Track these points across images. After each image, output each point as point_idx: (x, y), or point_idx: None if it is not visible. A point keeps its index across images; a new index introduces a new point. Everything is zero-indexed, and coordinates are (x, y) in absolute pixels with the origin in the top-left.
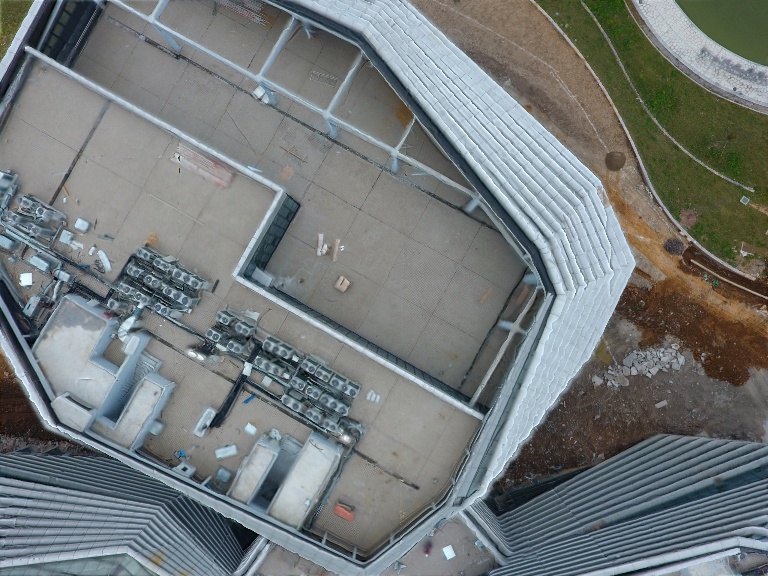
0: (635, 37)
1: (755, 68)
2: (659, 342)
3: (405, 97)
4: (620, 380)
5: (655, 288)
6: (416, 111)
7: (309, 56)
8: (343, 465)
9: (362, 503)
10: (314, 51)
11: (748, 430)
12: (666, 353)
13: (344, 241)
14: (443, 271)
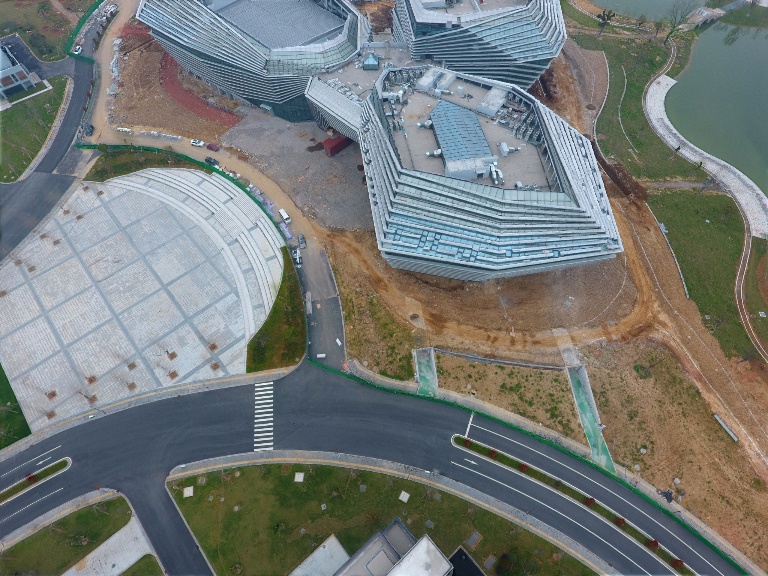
0: (637, 99)
1: (678, 135)
2: None
3: None
4: None
5: None
6: None
7: None
8: None
9: None
10: None
11: None
12: None
13: (487, 4)
14: None
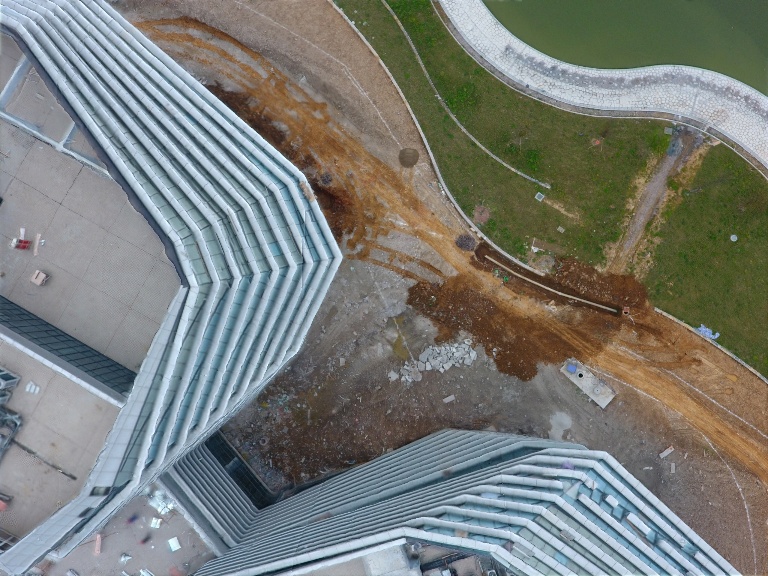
0: (438, 35)
1: (558, 65)
2: (453, 337)
3: (55, 92)
4: (413, 375)
5: (446, 284)
6: (64, 106)
7: (13, 53)
8: (3, 456)
9: (22, 493)
10: (18, 48)
11: (535, 425)
12: (459, 348)
13: (45, 235)
14: (141, 265)
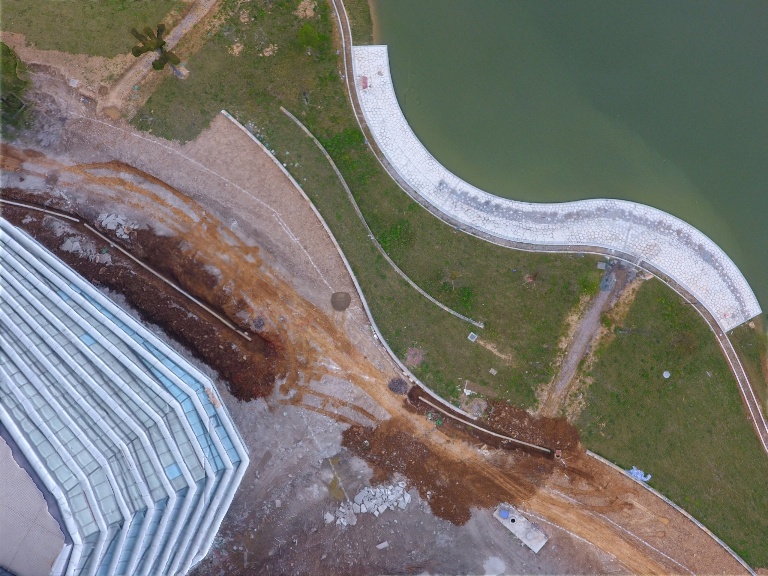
0: (372, 171)
1: (492, 200)
2: (388, 479)
3: None
4: (348, 518)
5: (379, 428)
6: None
7: None
8: None
9: None
10: None
11: (468, 570)
12: (394, 491)
13: None
14: None
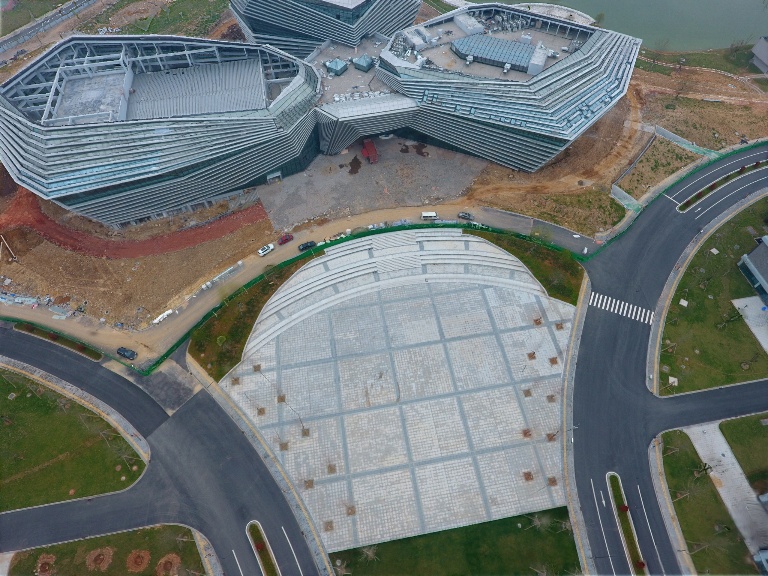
0: None
1: None
2: None
3: None
4: None
5: None
6: None
7: None
8: None
9: None
10: None
11: None
12: None
13: None
14: None
